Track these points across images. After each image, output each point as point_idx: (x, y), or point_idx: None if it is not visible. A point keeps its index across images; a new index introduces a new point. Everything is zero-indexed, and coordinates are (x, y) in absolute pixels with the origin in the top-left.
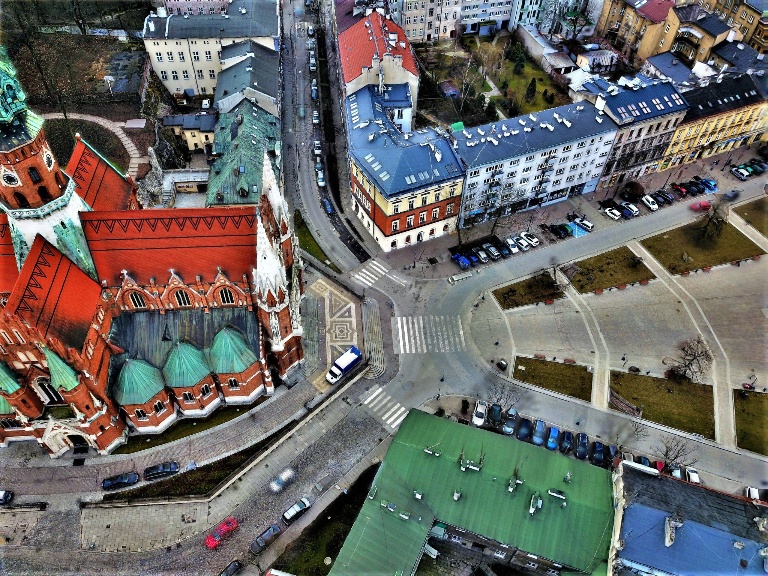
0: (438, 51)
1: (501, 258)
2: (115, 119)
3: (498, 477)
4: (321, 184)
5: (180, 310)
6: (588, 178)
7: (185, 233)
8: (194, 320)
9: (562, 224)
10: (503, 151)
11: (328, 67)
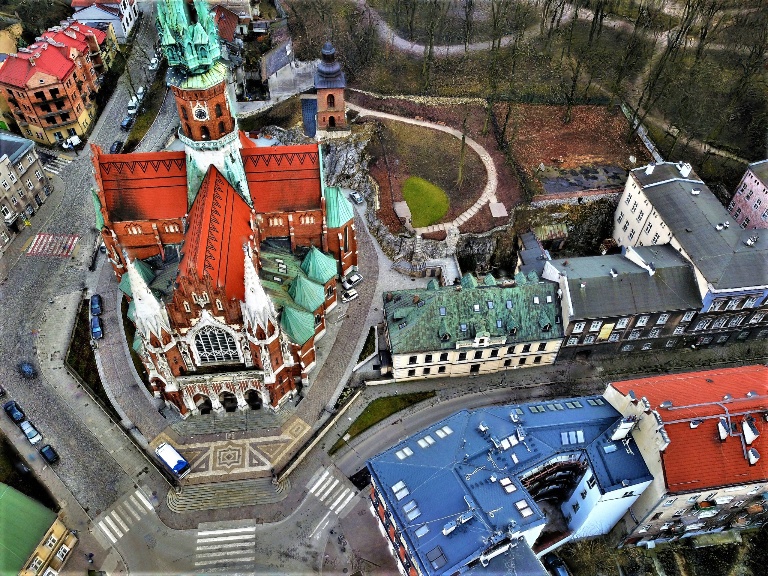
0: None
1: None
2: (500, 194)
3: None
4: None
5: None
6: None
7: None
8: None
9: None
10: None
11: None
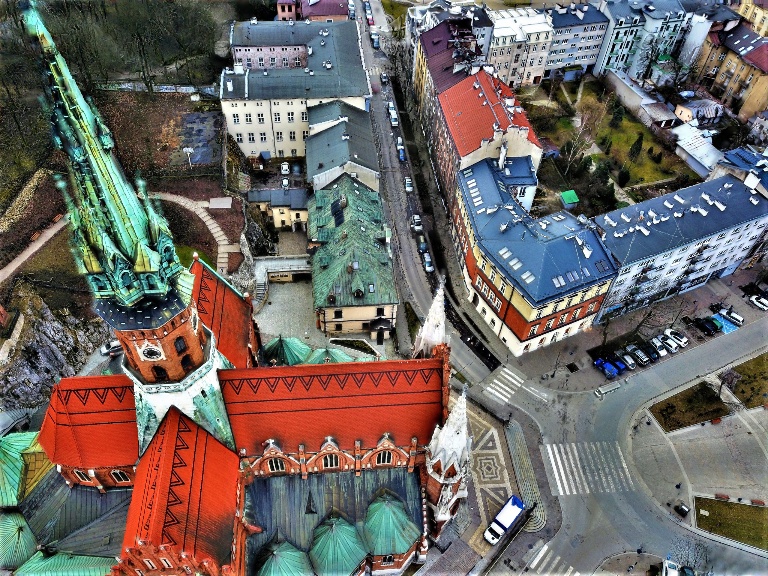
0: (522, 100)
1: (649, 363)
2: (197, 197)
3: None
4: (429, 269)
5: (325, 473)
6: (731, 262)
7: (346, 391)
8: (342, 485)
9: (708, 317)
10: (656, 243)
11: (411, 122)
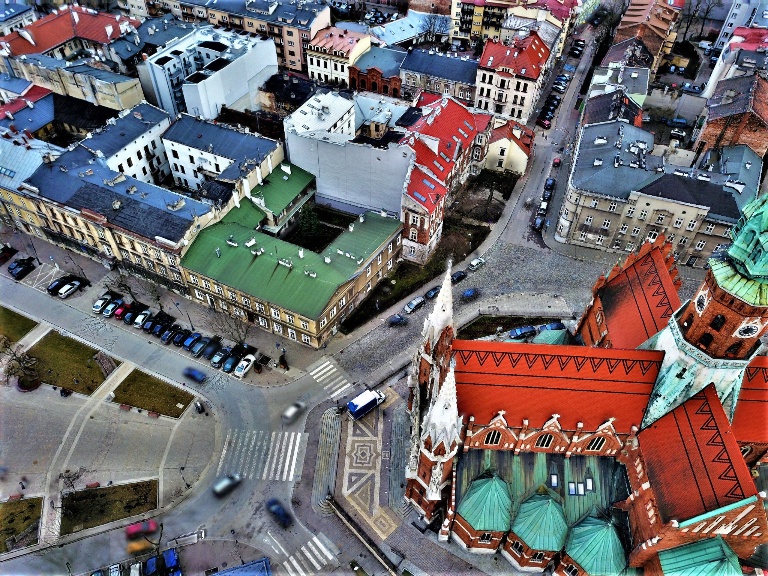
0: None
1: None
2: None
3: (268, 256)
4: None
5: None
6: None
7: None
8: None
9: None
10: None
11: None
